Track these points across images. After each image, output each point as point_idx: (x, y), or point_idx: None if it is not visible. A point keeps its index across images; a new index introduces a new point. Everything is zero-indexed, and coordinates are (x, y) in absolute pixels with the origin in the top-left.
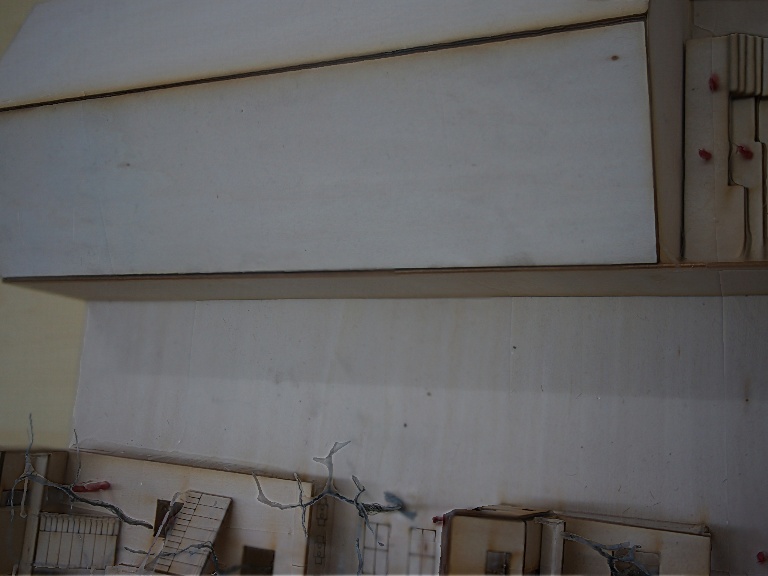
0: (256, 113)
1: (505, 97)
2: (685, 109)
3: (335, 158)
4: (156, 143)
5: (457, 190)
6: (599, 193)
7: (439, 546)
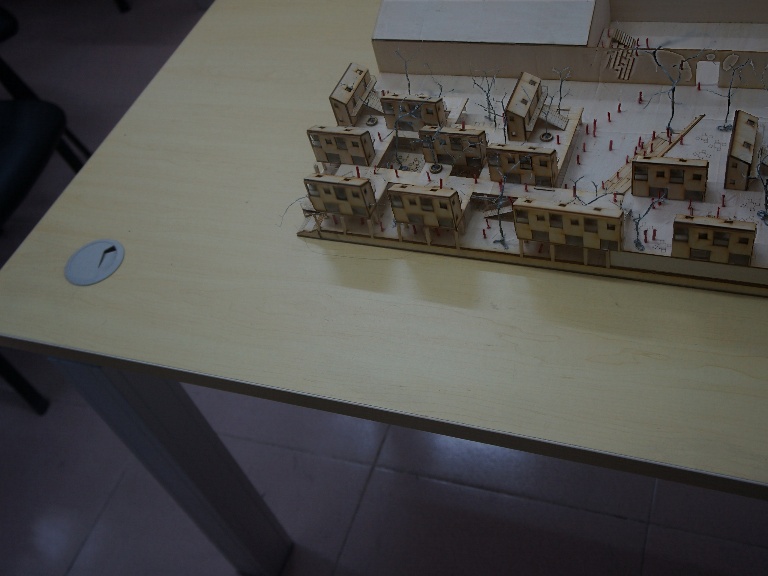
0: (488, 2)
1: (559, 6)
2: (600, 40)
3: (508, 15)
4: (452, 6)
5: (540, 25)
6: (577, 28)
7: None
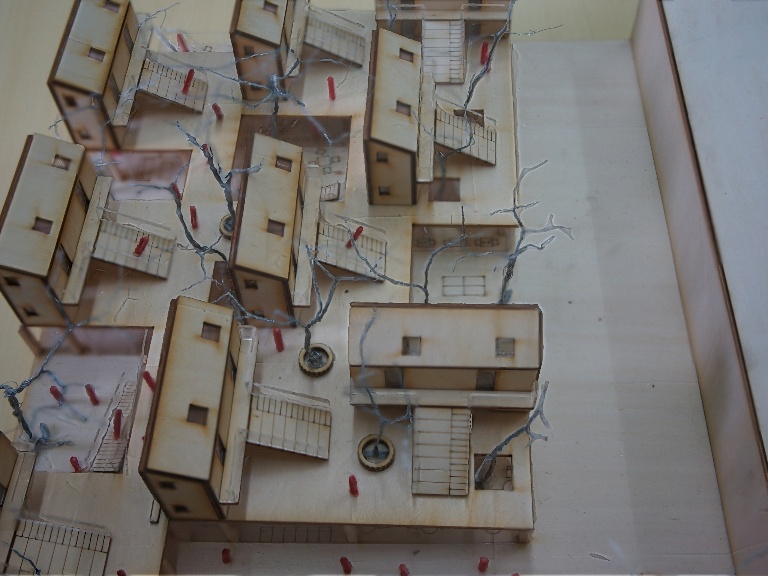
0: None
1: None
2: None
3: None
4: None
5: None
6: None
7: None
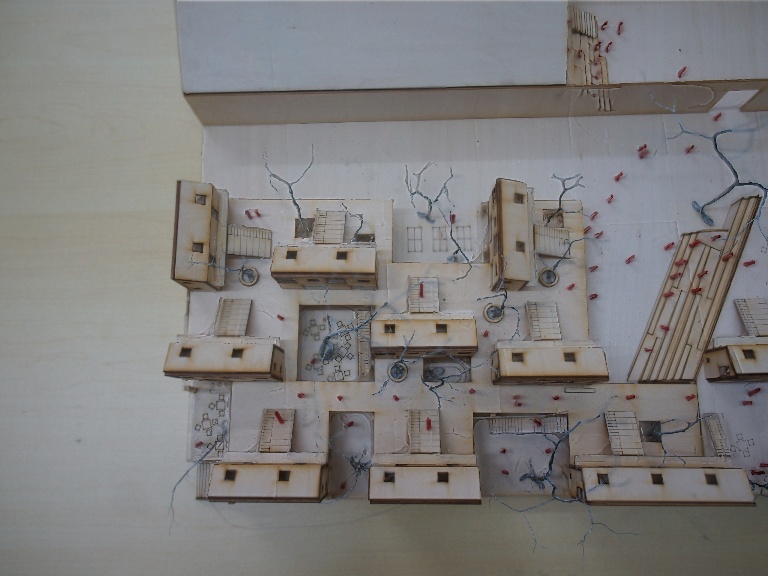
0: (381, 5)
1: (508, 8)
2: None
3: (423, 31)
4: (316, 17)
5: (482, 49)
6: (545, 53)
7: (449, 233)
